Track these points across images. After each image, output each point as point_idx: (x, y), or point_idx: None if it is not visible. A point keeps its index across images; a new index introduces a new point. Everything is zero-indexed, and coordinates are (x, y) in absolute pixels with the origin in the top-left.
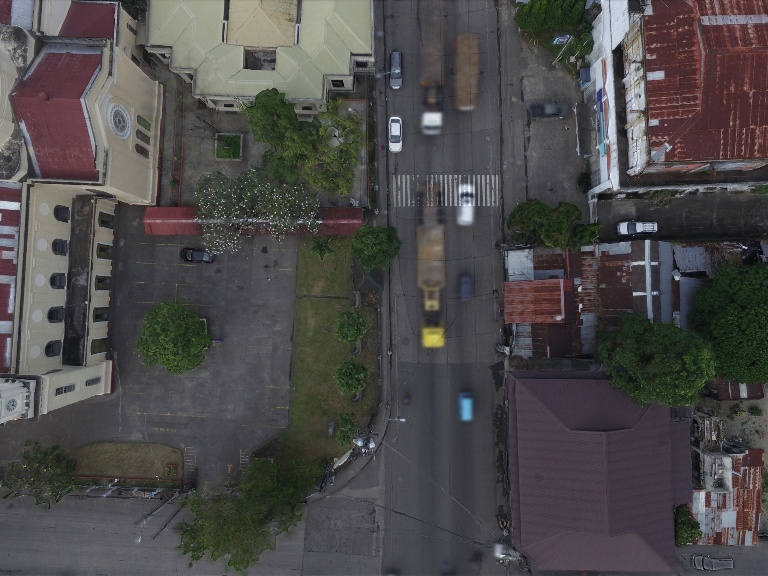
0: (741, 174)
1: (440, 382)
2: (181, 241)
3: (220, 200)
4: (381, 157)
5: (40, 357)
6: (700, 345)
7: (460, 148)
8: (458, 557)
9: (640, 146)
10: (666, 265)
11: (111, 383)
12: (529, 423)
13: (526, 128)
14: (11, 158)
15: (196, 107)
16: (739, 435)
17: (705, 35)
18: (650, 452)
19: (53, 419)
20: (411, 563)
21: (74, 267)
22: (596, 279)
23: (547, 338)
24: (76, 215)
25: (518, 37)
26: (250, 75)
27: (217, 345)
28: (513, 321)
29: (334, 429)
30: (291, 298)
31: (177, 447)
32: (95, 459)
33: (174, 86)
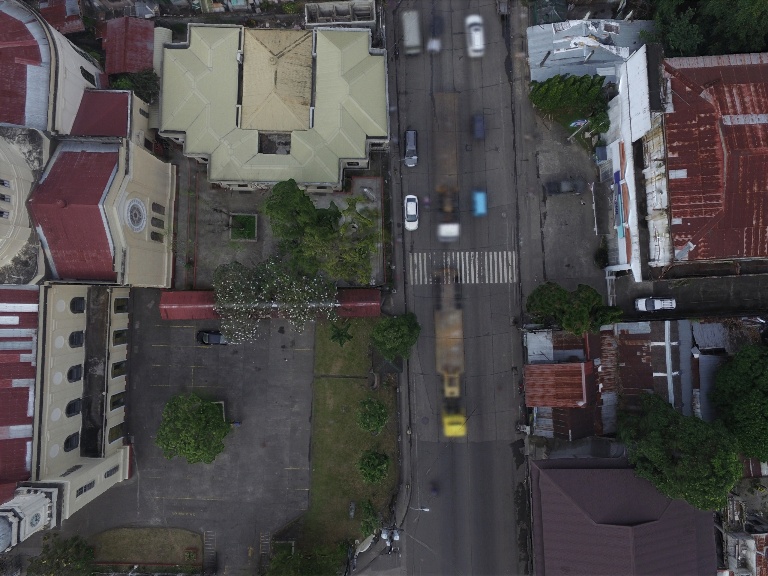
0: (762, 263)
1: (460, 461)
2: (197, 323)
3: (239, 293)
4: (397, 235)
5: (59, 455)
6: (727, 446)
7: (476, 225)
8: None
9: (663, 243)
10: (685, 343)
11: (129, 468)
12: (554, 515)
13: (542, 204)
14: (28, 263)
15: (210, 187)
16: (760, 509)
17: (727, 135)
18: (676, 542)
19: None
20: None
21: (90, 357)
22: (615, 358)
23: (569, 421)
24: (91, 304)
25: (532, 112)
26: (265, 160)
27: (235, 427)
28: (534, 404)
29: (355, 510)
30: (309, 378)
31: (196, 531)
32: (113, 545)
33: (187, 166)
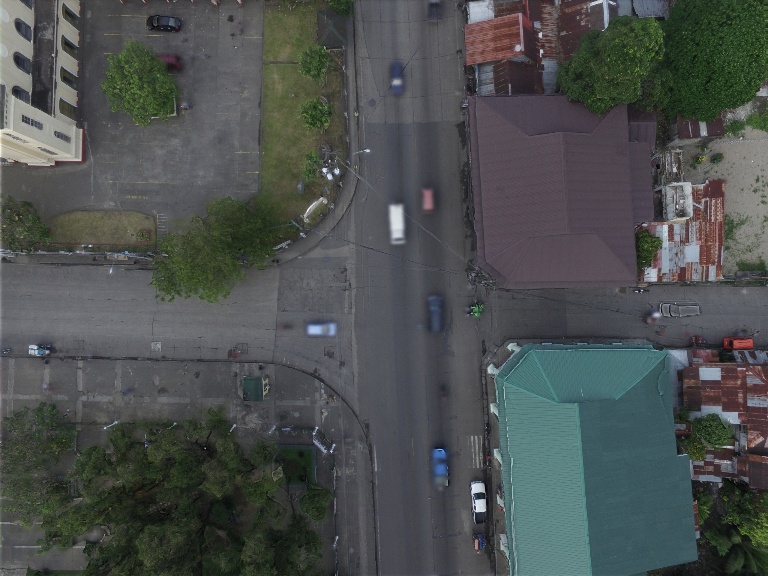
0: None
1: (407, 141)
2: (147, 12)
3: None
4: None
5: None
6: None
7: None
8: (429, 311)
9: None
10: (625, 10)
11: (82, 151)
12: (489, 137)
13: None
14: None
15: None
16: None
17: None
18: (608, 160)
19: (26, 190)
20: (383, 319)
21: (40, 22)
22: (556, 27)
23: (508, 76)
24: None
25: None
26: None
27: (186, 113)
28: (474, 61)
29: (304, 190)
30: (258, 65)
31: (149, 214)
32: (69, 228)
33: None
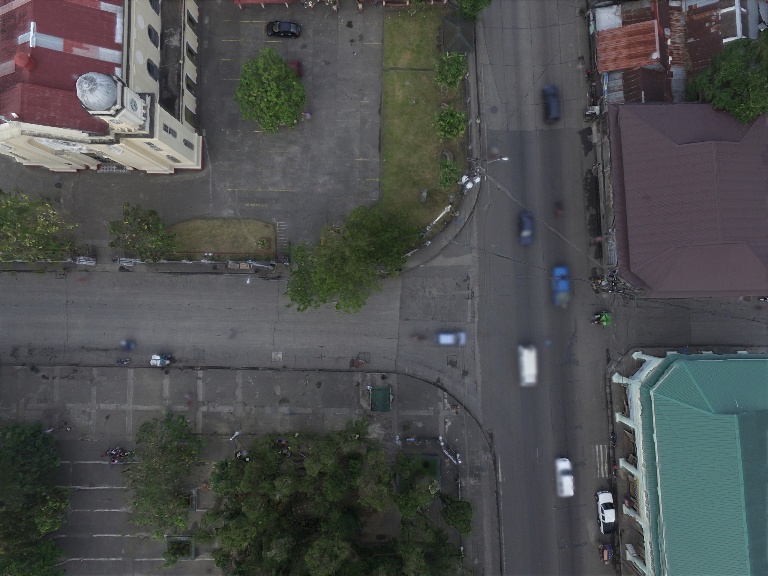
0: None
1: (529, 148)
2: (266, 18)
3: None
4: None
5: None
6: None
7: None
8: (553, 319)
9: None
10: (753, 16)
11: (201, 158)
12: (634, 146)
13: None
14: None
15: None
16: None
17: None
18: (755, 169)
19: (144, 198)
20: (507, 327)
21: (166, 28)
22: (684, 34)
23: (641, 83)
24: None
25: None
26: None
27: (305, 120)
28: (607, 68)
29: (426, 198)
30: (378, 71)
31: (269, 222)
32: (187, 236)
33: None
